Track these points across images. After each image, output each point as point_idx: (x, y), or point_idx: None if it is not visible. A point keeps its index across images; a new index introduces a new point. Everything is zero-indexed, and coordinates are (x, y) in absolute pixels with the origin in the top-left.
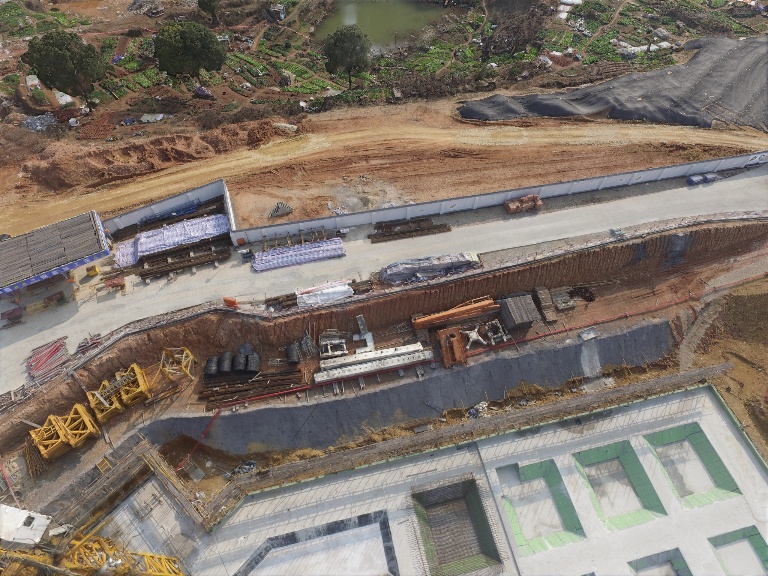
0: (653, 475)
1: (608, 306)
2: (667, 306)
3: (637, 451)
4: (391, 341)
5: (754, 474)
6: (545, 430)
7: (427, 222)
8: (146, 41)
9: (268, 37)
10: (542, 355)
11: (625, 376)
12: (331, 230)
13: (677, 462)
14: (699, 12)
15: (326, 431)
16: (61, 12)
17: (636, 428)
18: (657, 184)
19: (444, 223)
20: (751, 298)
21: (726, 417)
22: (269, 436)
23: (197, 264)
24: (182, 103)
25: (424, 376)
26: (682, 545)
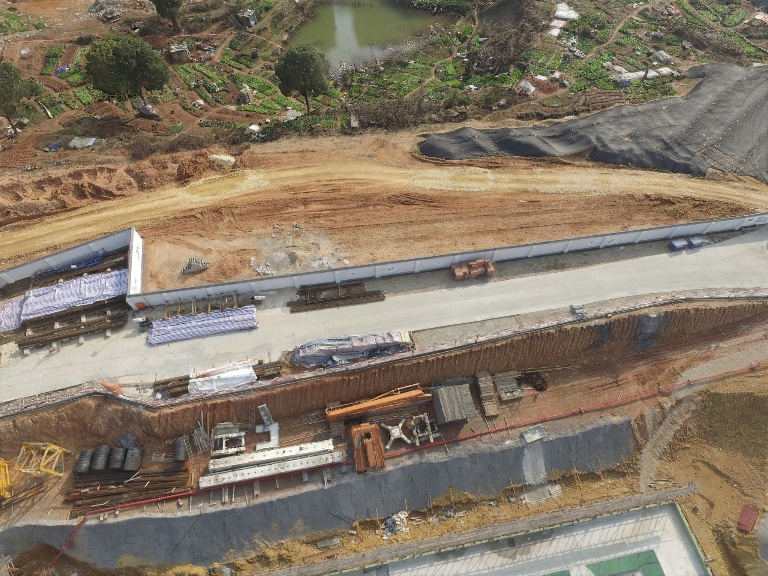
0: None
1: (561, 398)
2: (631, 401)
3: None
4: (300, 434)
5: None
6: (471, 552)
7: (359, 287)
8: None
9: (234, 46)
10: (475, 459)
11: (575, 484)
12: (247, 294)
13: None
14: (709, 32)
15: (211, 545)
16: (18, 12)
17: (579, 555)
18: (633, 248)
19: (378, 289)
20: (731, 397)
21: (689, 545)
22: (144, 548)
23: (85, 333)
24: (122, 123)
25: (331, 482)
26: None
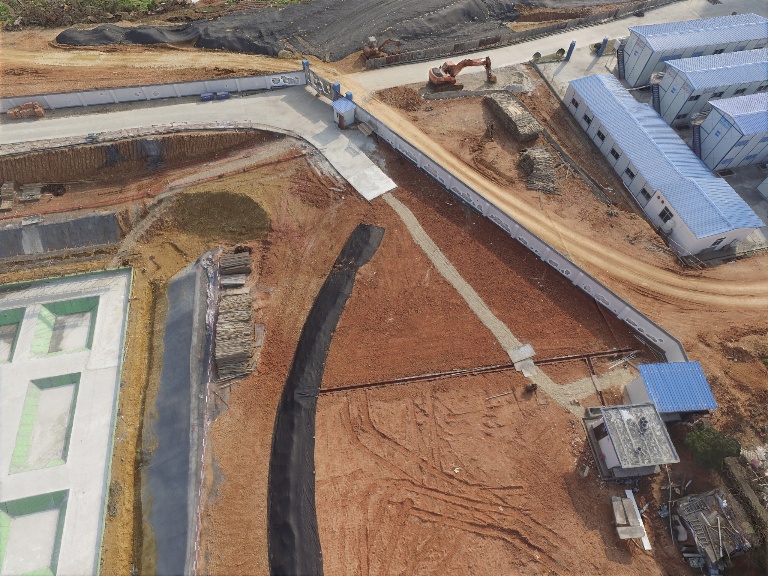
0: (25, 333)
1: (71, 200)
2: (124, 201)
3: (26, 315)
4: None
5: (115, 335)
6: None
7: None
8: None
9: None
10: None
11: None
12: None
13: (67, 327)
14: None
15: None
16: None
17: (41, 298)
18: (173, 100)
19: None
20: (196, 196)
21: None
22: None
23: None
24: None
25: None
26: (4, 384)
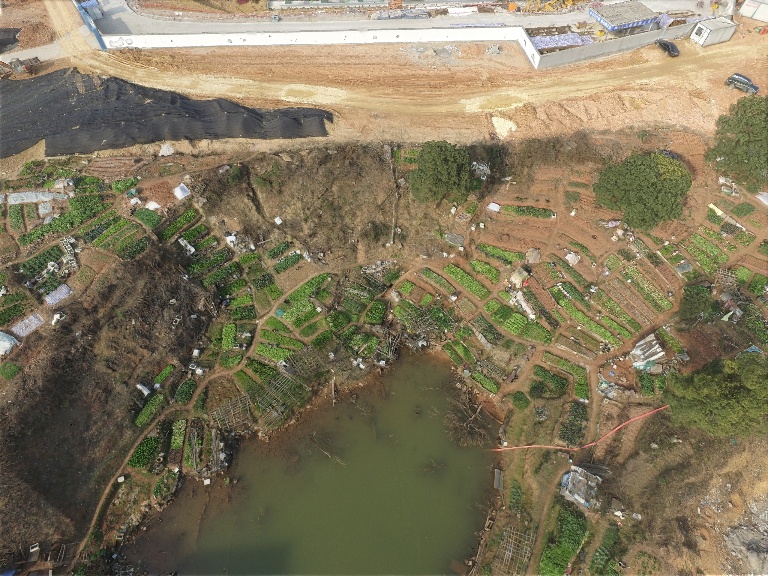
0: None
1: None
2: None
3: None
4: None
5: None
6: None
7: None
8: (767, 337)
9: (577, 405)
10: None
11: None
12: None
13: (303, 3)
14: None
15: None
16: None
17: (315, 5)
18: None
19: None
20: None
21: (270, 4)
22: None
23: None
24: None
25: None
26: None
